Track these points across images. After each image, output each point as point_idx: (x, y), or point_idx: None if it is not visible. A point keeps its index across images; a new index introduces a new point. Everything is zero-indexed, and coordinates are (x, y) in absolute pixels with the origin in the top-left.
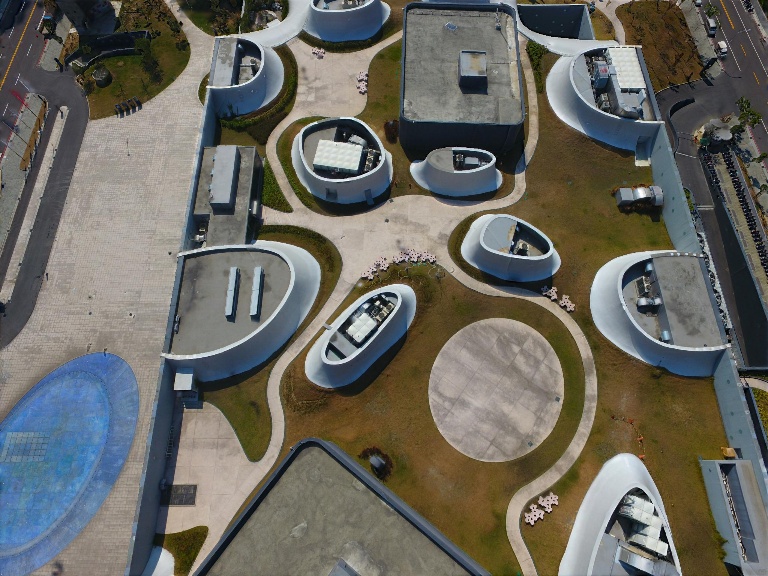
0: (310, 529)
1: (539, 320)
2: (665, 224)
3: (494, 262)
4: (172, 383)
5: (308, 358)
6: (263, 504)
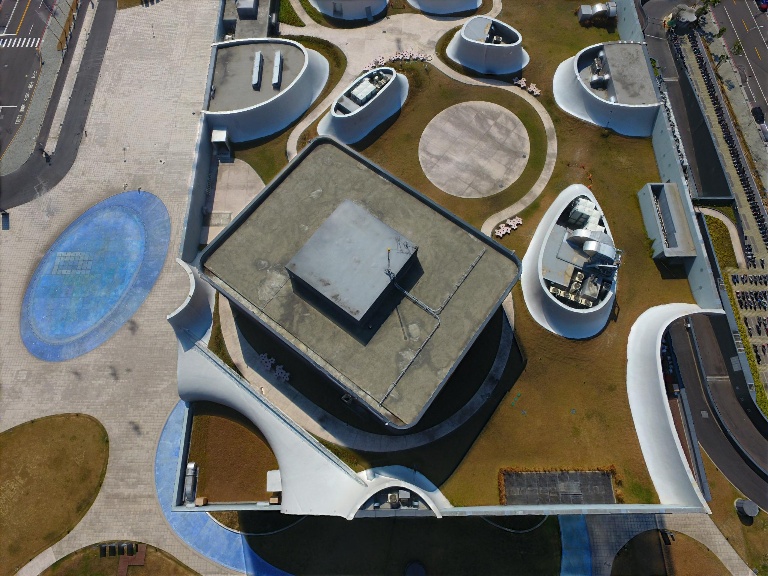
0: (325, 193)
1: (511, 102)
2: (619, 35)
3: (473, 54)
4: (210, 137)
5: (320, 124)
6: (288, 178)
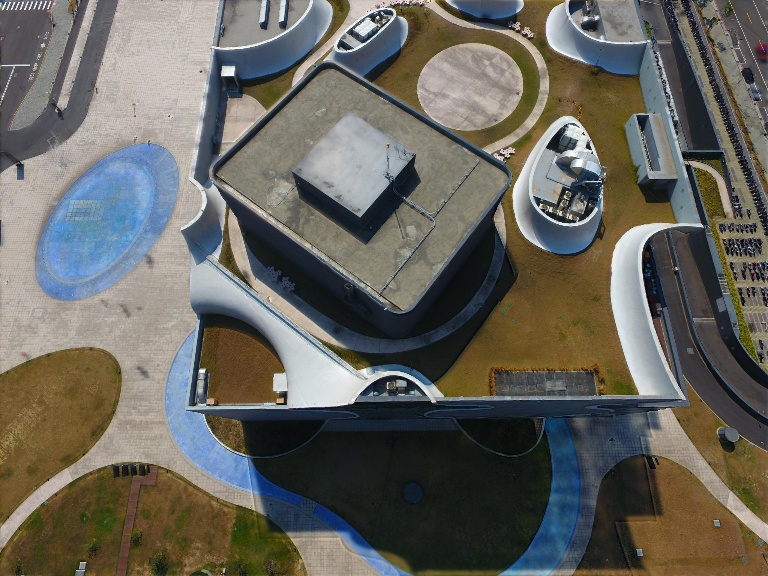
0: (328, 112)
1: (505, 44)
2: None
3: None
4: (219, 72)
5: None
6: (294, 99)
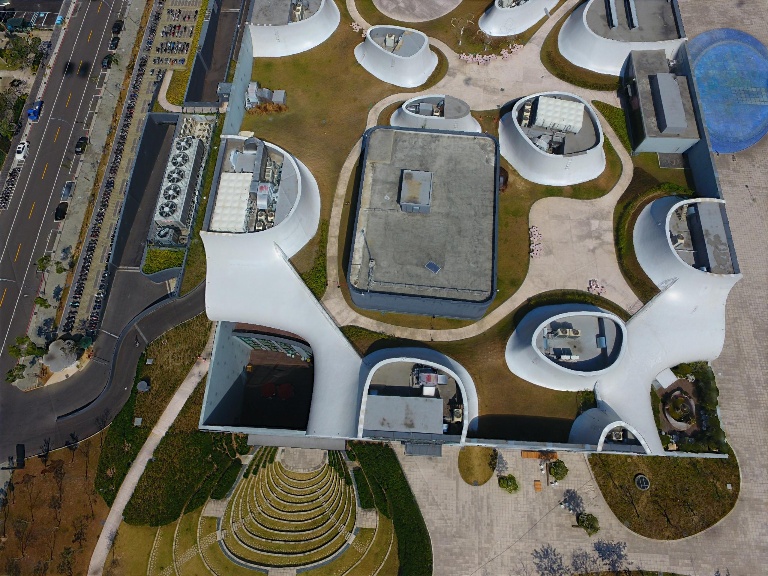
0: None
1: (380, 20)
2: None
3: None
4: None
5: None
6: None
